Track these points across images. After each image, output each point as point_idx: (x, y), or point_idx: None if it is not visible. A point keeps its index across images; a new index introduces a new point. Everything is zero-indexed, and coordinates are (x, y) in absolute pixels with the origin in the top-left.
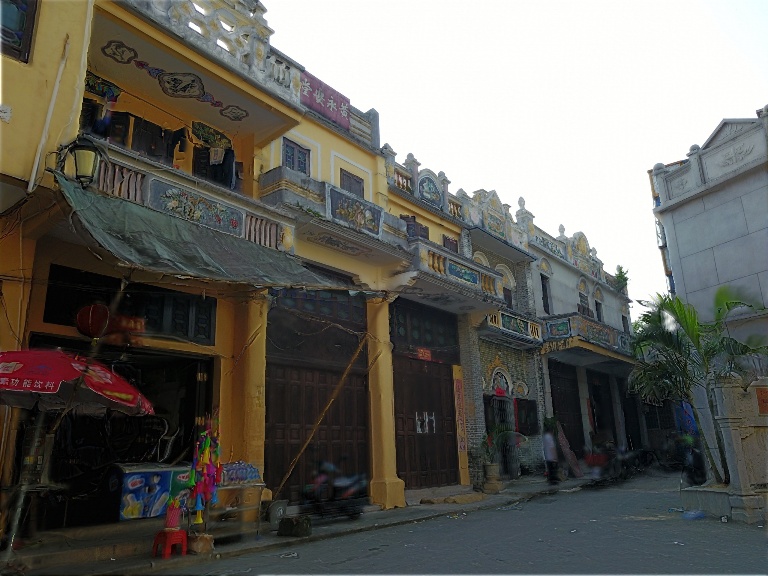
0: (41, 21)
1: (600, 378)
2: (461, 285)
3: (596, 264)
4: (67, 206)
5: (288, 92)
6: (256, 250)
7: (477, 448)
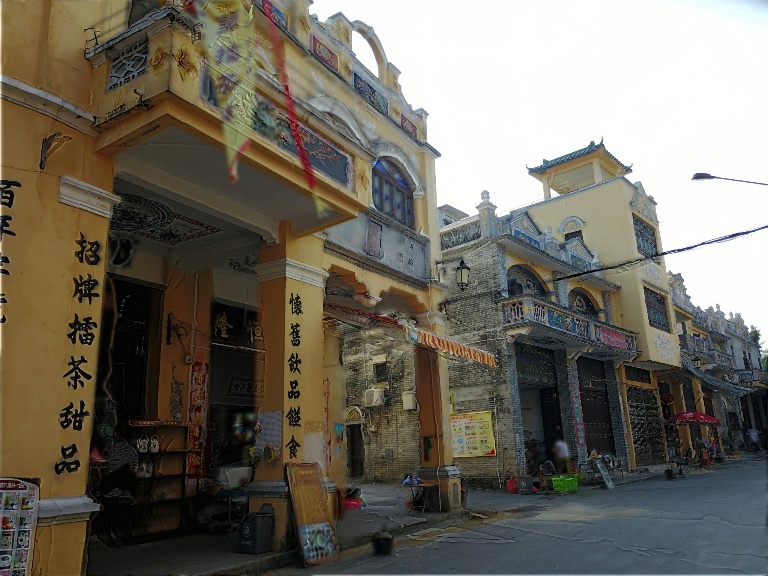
0: (671, 320)
1: (755, 398)
2: (725, 366)
3: (746, 330)
4: (695, 375)
5: (690, 309)
6: (703, 373)
7: (726, 436)
